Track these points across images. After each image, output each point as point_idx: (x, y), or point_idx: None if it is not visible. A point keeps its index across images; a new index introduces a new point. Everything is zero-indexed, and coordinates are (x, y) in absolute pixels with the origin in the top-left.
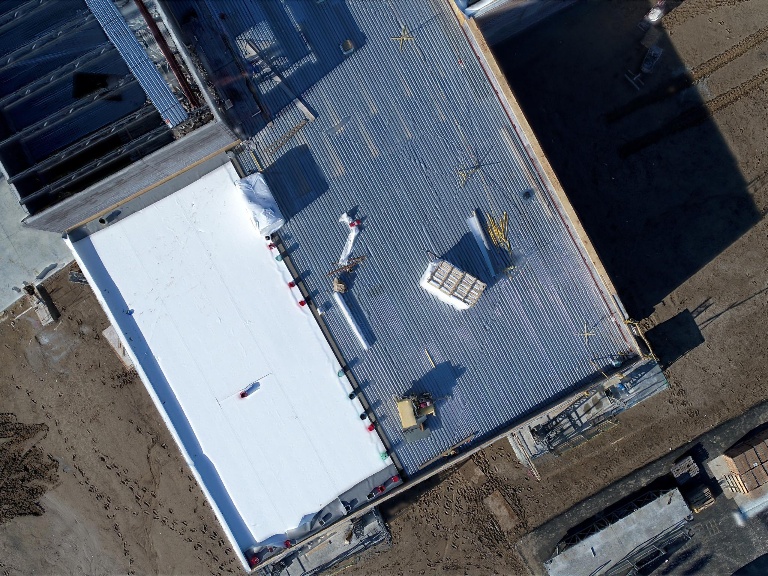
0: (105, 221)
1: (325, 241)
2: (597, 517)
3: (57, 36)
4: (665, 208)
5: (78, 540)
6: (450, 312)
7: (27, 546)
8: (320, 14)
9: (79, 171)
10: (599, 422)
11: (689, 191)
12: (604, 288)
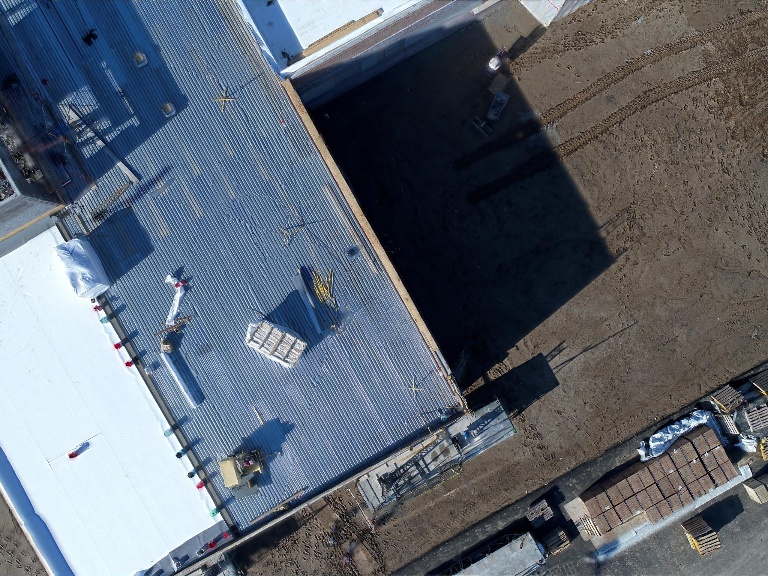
0: None
1: (152, 302)
2: (454, 561)
3: None
4: (517, 253)
5: None
6: (277, 369)
7: None
8: (142, 78)
9: None
10: (444, 470)
11: (541, 236)
12: (428, 344)
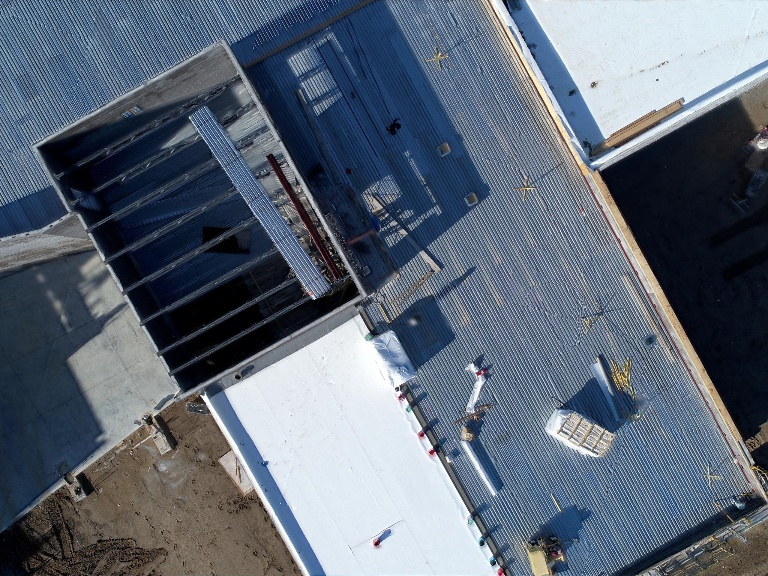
0: (240, 377)
1: (452, 390)
2: None
3: (201, 210)
4: None
5: None
6: (575, 457)
7: None
8: (444, 167)
9: (226, 343)
10: (712, 549)
11: None
12: (729, 433)
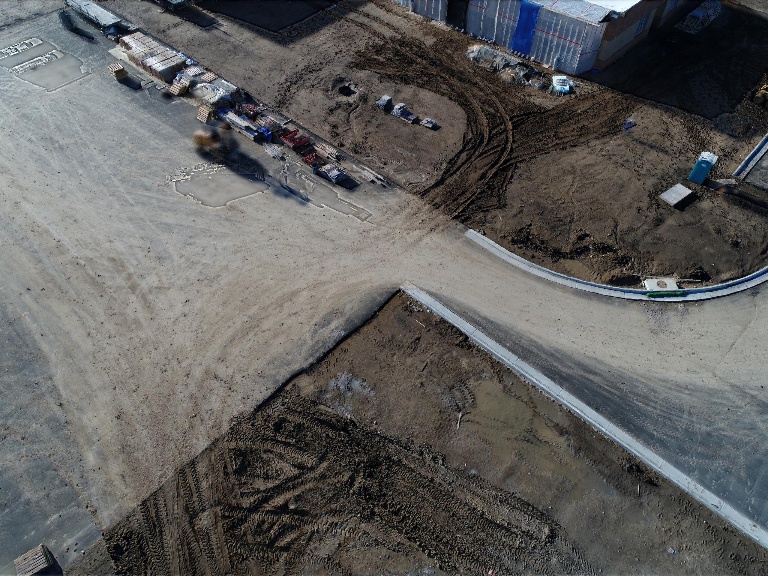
0: None
1: None
2: None
3: None
4: (269, 8)
5: None
6: None
7: None
8: None
9: None
10: None
11: None
12: None
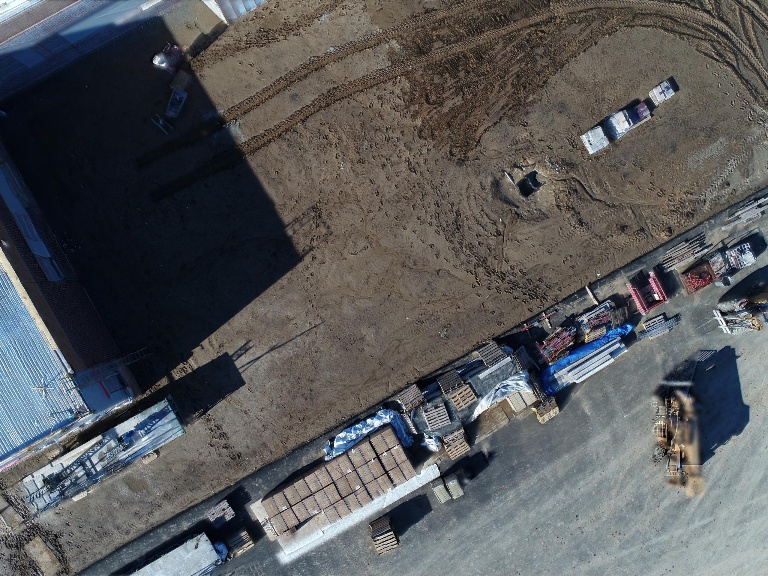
0: None
1: None
2: (139, 561)
3: None
4: (201, 252)
5: None
6: None
7: None
8: None
9: None
10: None
11: (225, 234)
12: None
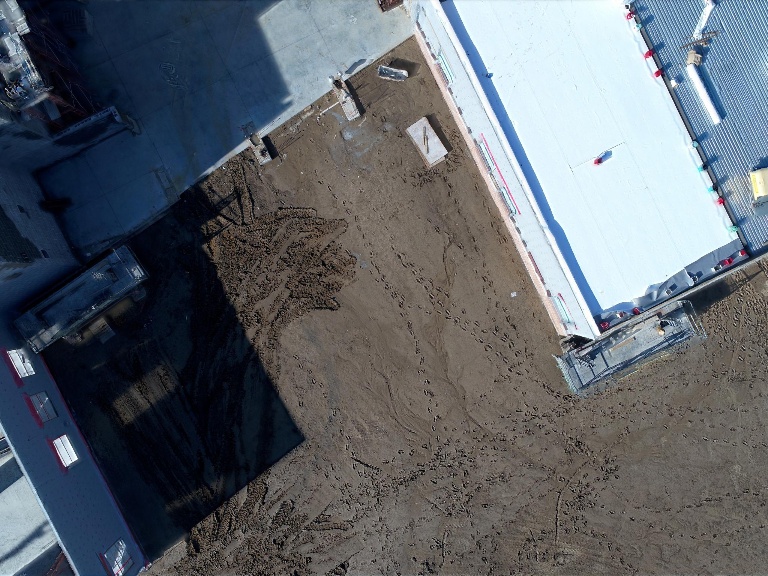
0: None
1: (680, 14)
2: None
3: None
4: None
5: (371, 337)
6: None
7: (321, 340)
8: None
9: None
10: None
11: None
12: None
